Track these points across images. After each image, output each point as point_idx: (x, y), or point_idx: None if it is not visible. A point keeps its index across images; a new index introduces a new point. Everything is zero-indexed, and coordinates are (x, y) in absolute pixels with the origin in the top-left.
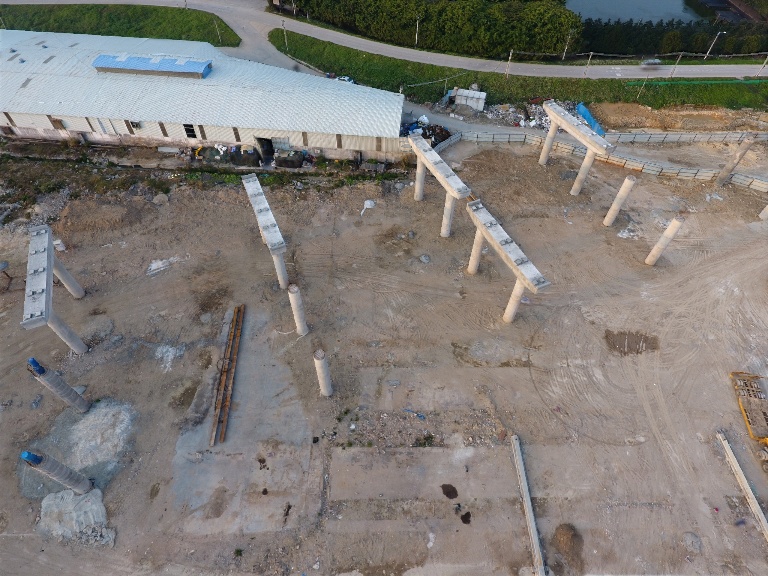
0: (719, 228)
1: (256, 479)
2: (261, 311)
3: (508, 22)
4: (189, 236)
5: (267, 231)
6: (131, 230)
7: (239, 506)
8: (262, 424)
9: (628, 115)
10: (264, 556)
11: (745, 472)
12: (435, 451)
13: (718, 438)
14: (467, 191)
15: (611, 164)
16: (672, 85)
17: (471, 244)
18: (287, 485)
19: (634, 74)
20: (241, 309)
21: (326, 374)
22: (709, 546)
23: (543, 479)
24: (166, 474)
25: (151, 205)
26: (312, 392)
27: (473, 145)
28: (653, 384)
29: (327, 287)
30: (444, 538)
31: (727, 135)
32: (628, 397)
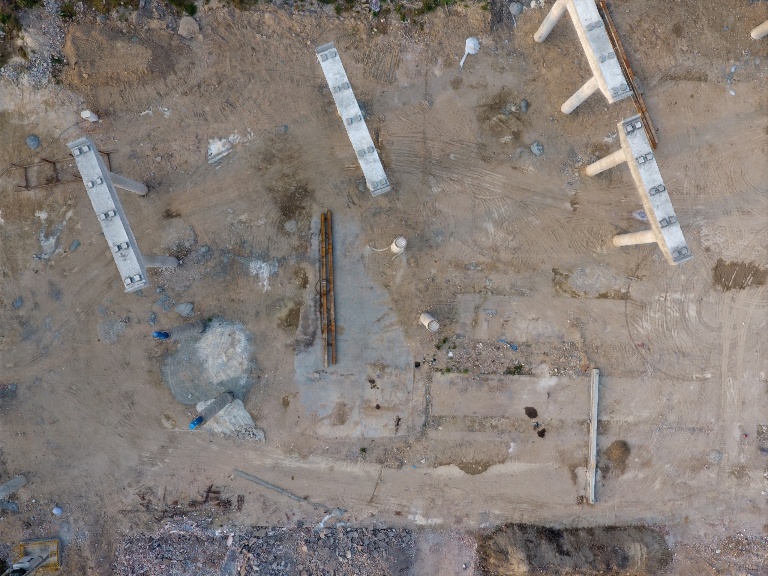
0: None
1: (369, 396)
2: (350, 220)
3: None
4: (243, 99)
5: (364, 160)
6: (167, 86)
7: (358, 417)
8: (368, 348)
9: None
10: (383, 453)
11: None
12: (523, 379)
13: None
14: (626, 95)
15: None
16: None
17: (597, 126)
18: (396, 402)
19: None
20: (328, 217)
21: None
22: (726, 460)
23: (611, 406)
24: (292, 389)
25: (179, 40)
26: (411, 319)
27: None
28: (742, 323)
29: (421, 189)
30: (522, 446)
31: None
32: (712, 335)
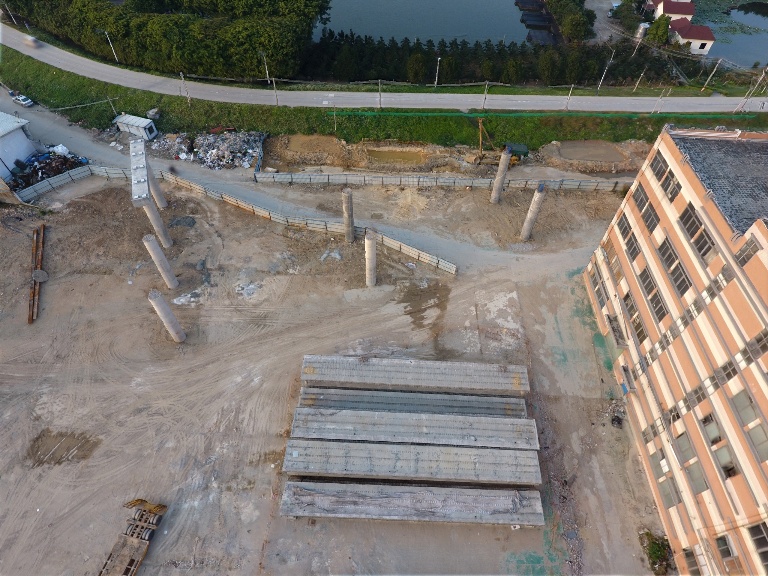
0: (305, 295)
1: None
2: None
3: (203, 40)
4: None
5: None
6: None
7: None
8: None
9: (313, 150)
10: None
11: None
12: None
13: None
14: None
15: (243, 209)
16: (381, 116)
17: None
18: None
19: (343, 102)
20: None
21: None
22: None
23: None
24: None
25: None
26: None
27: (102, 181)
28: (36, 509)
29: None
30: None
31: (402, 178)
32: None
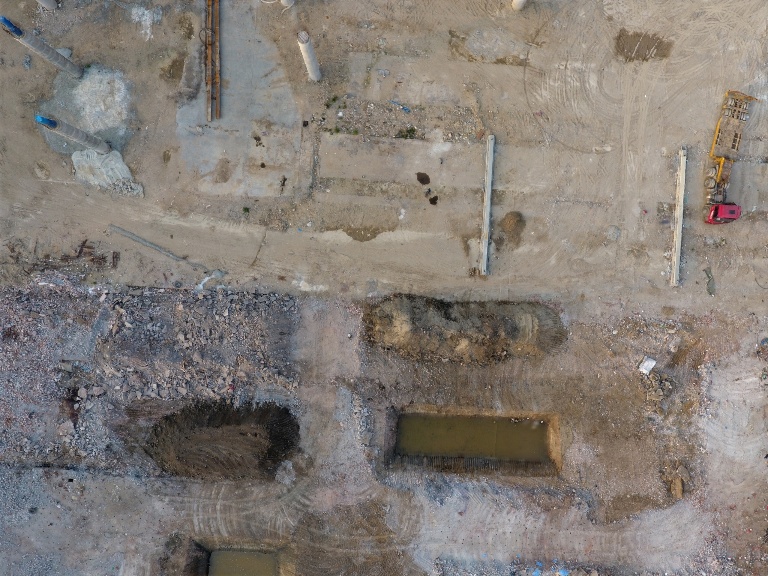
0: None
1: (254, 154)
2: None
3: None
4: None
5: None
6: None
7: (242, 175)
8: (254, 104)
9: None
10: (267, 214)
11: (687, 184)
12: (415, 143)
13: (680, 154)
14: None
15: None
16: None
17: None
18: (282, 161)
19: None
20: None
21: (312, 58)
22: (625, 237)
23: (507, 175)
24: (173, 143)
25: None
26: (300, 75)
27: None
28: (644, 96)
29: None
30: (413, 213)
31: None
32: (613, 107)
